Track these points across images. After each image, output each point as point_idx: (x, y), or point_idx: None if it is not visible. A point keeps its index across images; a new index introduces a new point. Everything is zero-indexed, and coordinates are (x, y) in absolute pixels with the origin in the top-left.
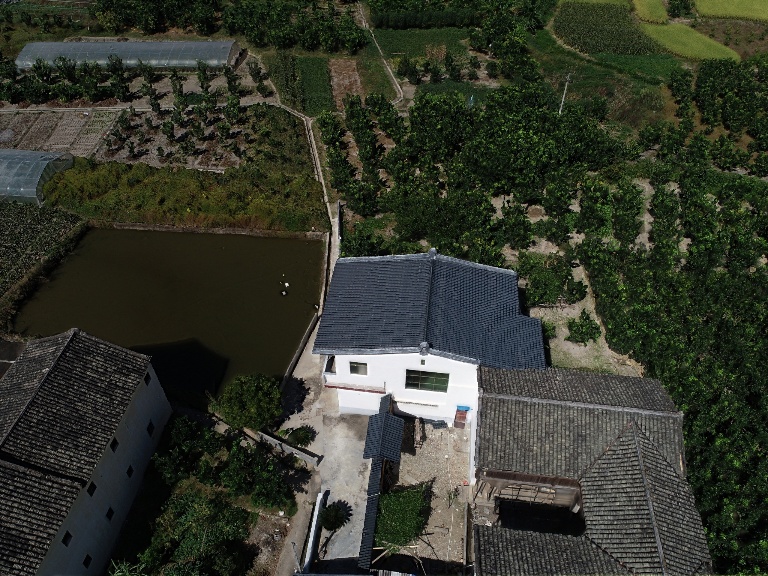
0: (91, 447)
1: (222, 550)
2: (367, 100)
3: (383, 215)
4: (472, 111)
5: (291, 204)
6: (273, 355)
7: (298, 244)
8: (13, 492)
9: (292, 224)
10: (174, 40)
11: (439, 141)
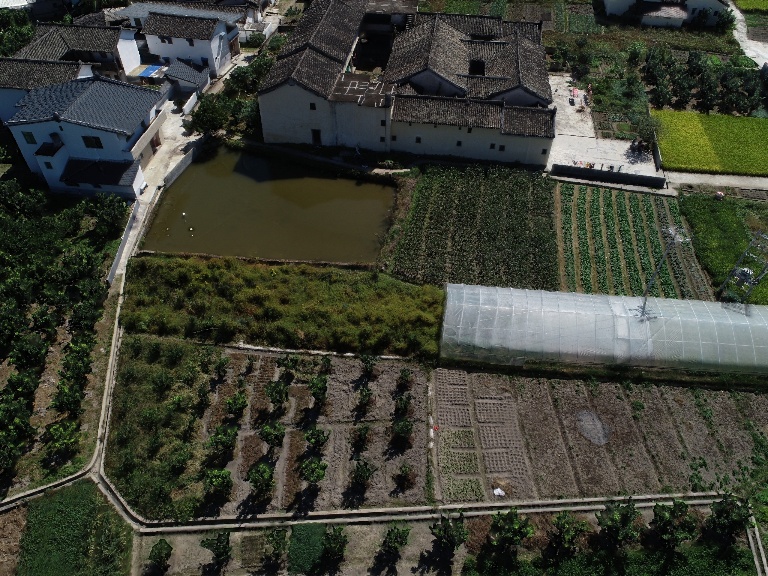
0: None
1: (229, 88)
2: None
3: None
4: None
5: (160, 262)
6: None
7: None
8: None
9: None
10: None
11: None
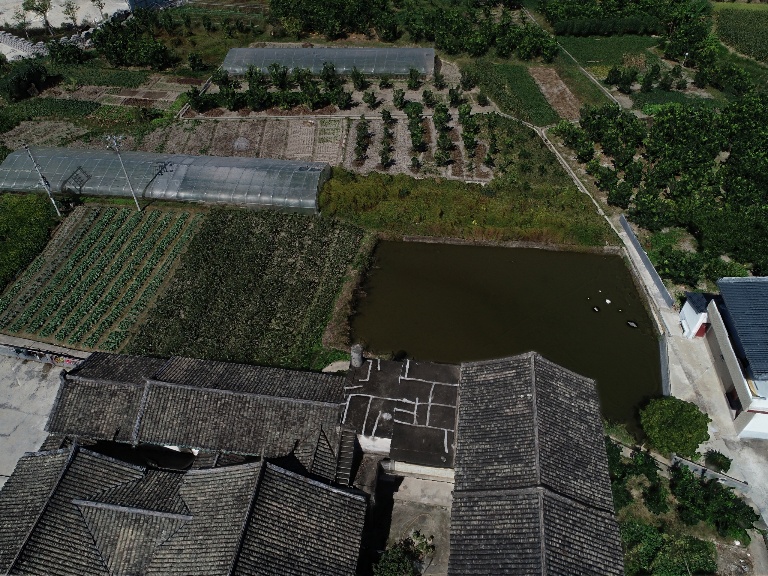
0: (599, 477)
1: None
2: (601, 110)
3: (669, 229)
4: (725, 123)
5: (583, 218)
6: (619, 374)
7: (595, 259)
8: (574, 526)
9: (585, 238)
10: (359, 46)
11: (705, 153)
